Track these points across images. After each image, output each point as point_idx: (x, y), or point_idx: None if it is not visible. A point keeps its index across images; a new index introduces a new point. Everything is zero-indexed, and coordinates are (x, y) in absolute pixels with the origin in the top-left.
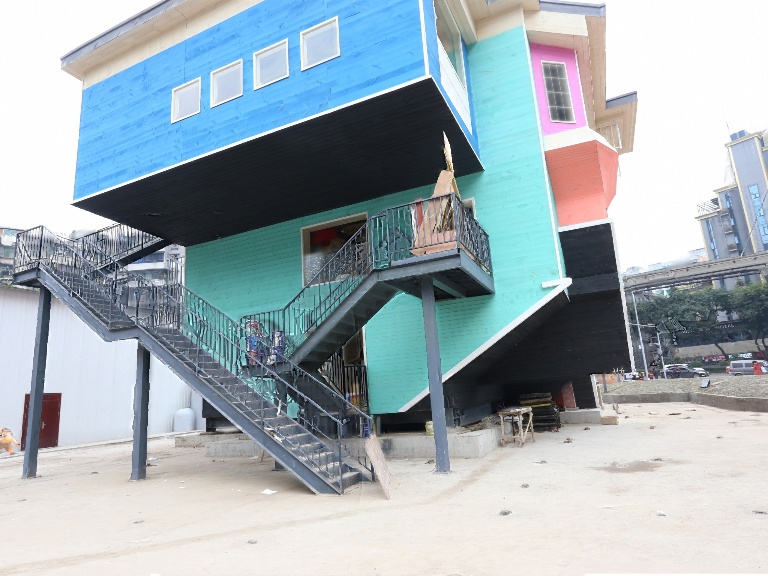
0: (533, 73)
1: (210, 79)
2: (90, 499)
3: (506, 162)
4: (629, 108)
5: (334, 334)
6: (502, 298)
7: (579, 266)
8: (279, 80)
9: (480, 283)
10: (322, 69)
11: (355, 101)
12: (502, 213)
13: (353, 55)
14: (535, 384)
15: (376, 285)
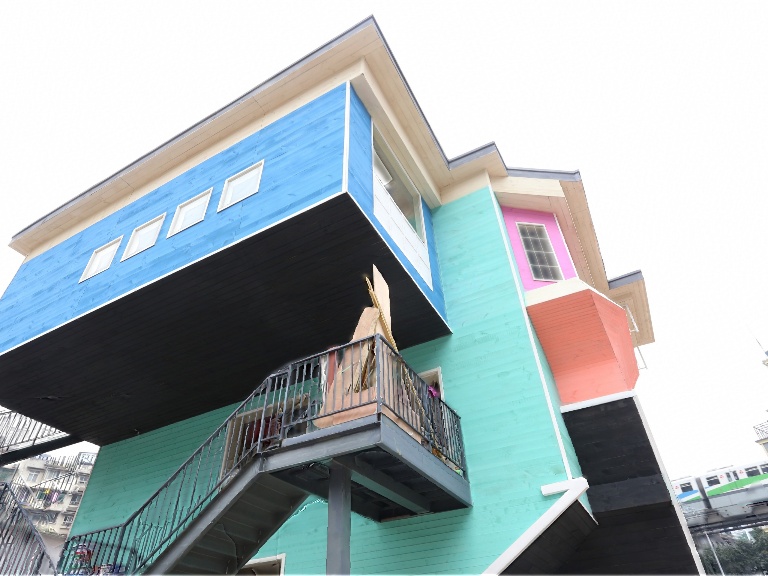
0: (507, 233)
1: (131, 235)
2: None
3: (479, 322)
4: (637, 288)
5: (196, 572)
6: (483, 514)
7: (600, 465)
8: (193, 225)
9: (435, 483)
10: (237, 207)
11: (260, 230)
12: (477, 385)
13: (271, 189)
14: None
15: (259, 480)
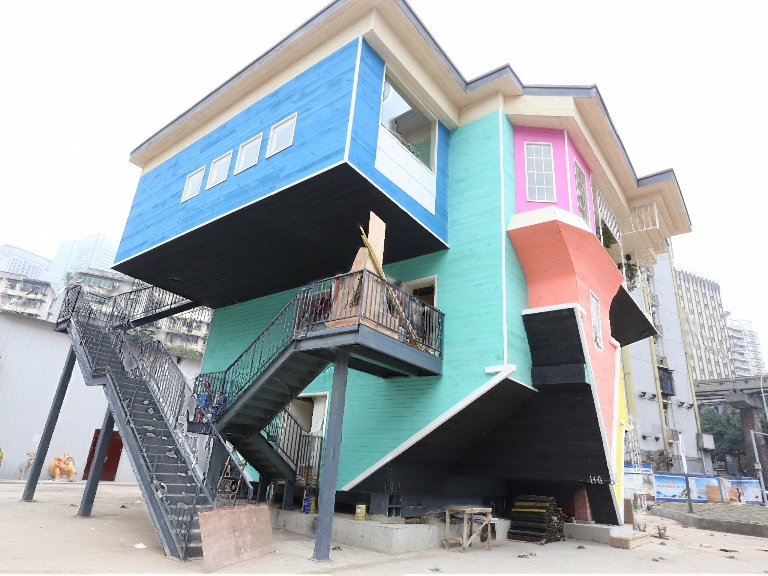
0: (513, 154)
1: (210, 167)
2: (10, 524)
3: (469, 241)
4: (666, 186)
5: (267, 400)
6: (448, 380)
7: (545, 353)
8: (250, 167)
9: None
10: (278, 157)
11: (291, 184)
12: (460, 292)
13: (300, 144)
14: (542, 485)
15: (295, 355)
